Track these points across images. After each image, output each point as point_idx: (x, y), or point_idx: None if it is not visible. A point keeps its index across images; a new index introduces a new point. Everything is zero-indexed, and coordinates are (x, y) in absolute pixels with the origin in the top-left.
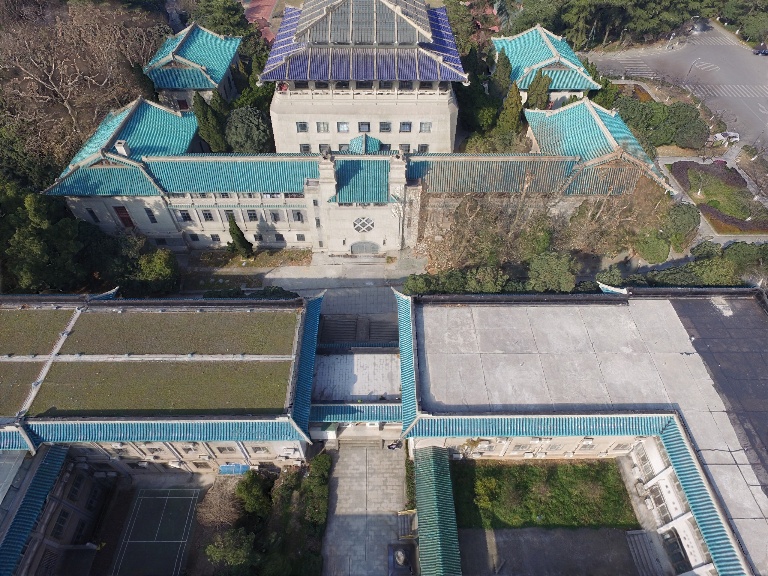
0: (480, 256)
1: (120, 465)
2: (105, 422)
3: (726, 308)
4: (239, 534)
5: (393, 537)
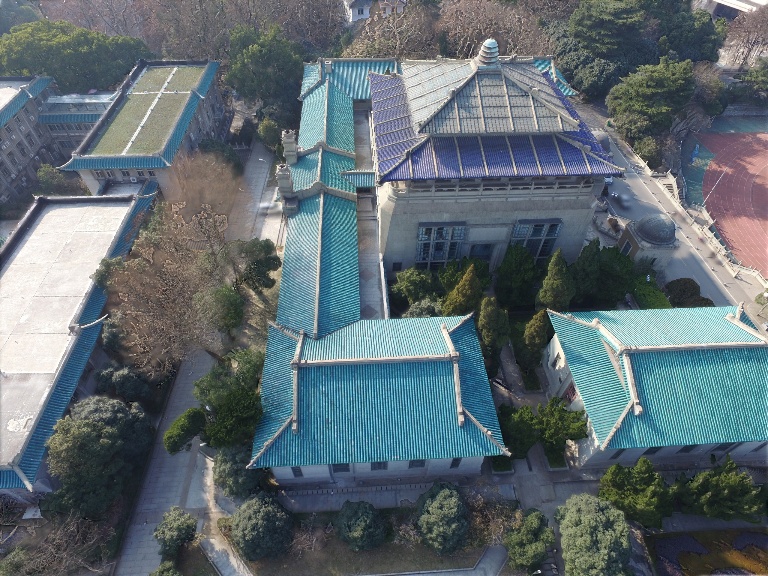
0: None
1: None
2: None
3: (19, 426)
4: None
5: None
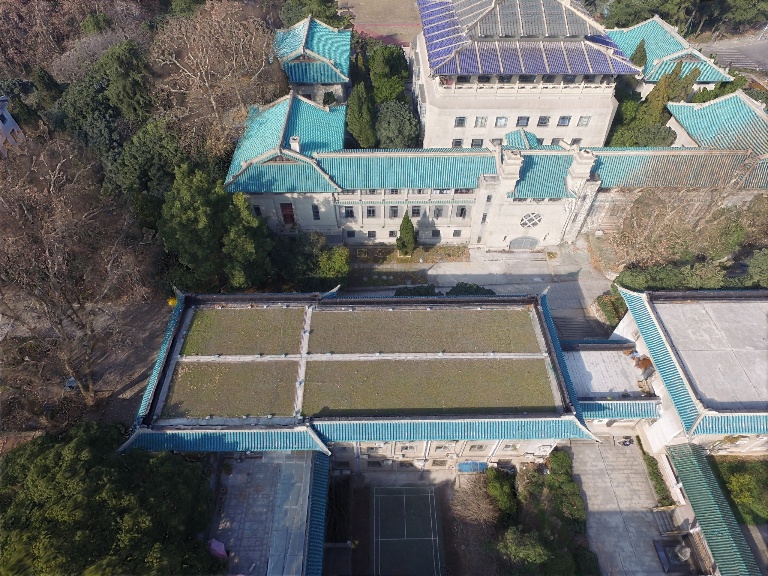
0: (673, 251)
1: (359, 463)
2: (390, 421)
3: None
4: (519, 532)
5: (655, 533)
